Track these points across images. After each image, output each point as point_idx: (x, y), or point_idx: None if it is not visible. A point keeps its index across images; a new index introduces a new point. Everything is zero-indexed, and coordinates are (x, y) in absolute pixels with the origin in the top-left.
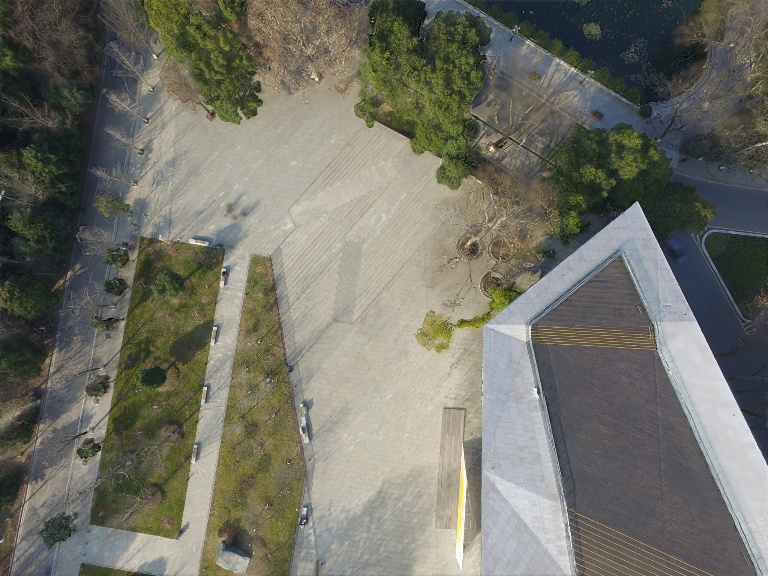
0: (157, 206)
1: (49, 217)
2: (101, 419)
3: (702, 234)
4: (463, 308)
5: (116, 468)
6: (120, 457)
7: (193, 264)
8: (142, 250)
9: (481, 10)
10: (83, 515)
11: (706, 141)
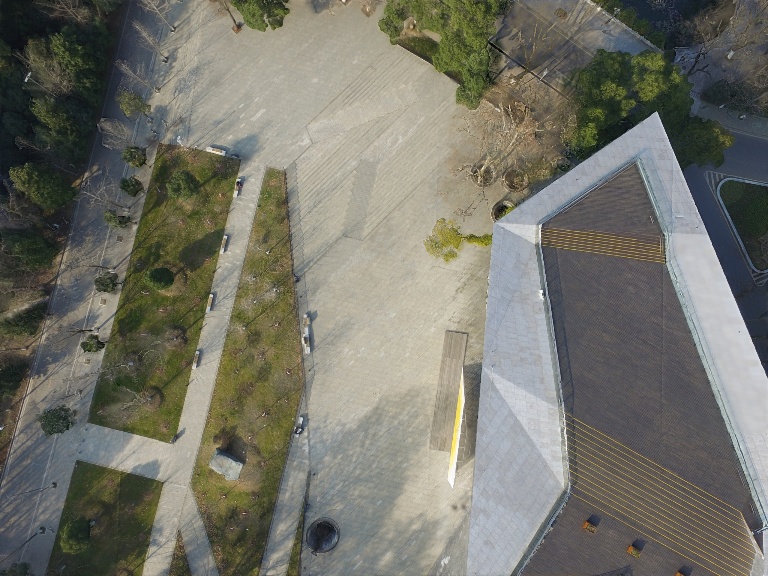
0: (177, 113)
1: (72, 110)
2: (107, 320)
3: (718, 182)
4: None
5: (118, 364)
6: (122, 358)
7: (208, 172)
8: (159, 156)
9: None
10: (82, 413)
11: (728, 87)
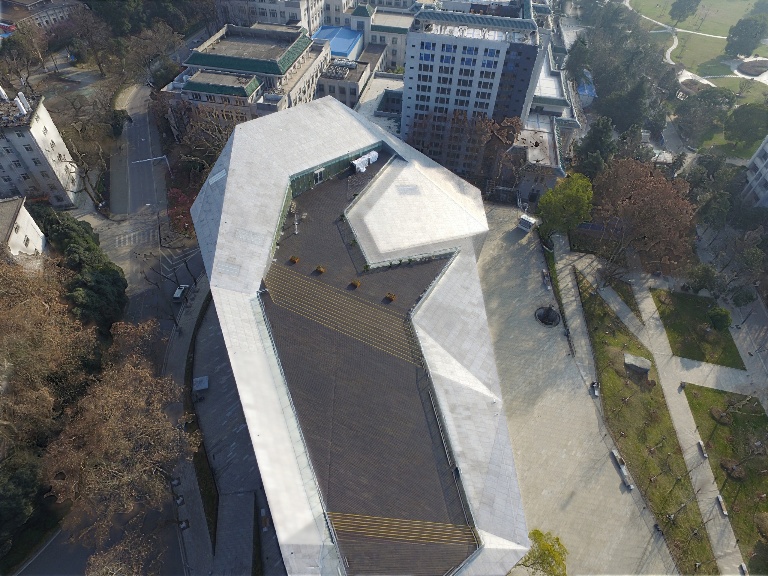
0: None
1: None
2: None
3: None
4: None
5: None
6: (767, 450)
7: None
8: None
9: None
10: (767, 405)
11: None
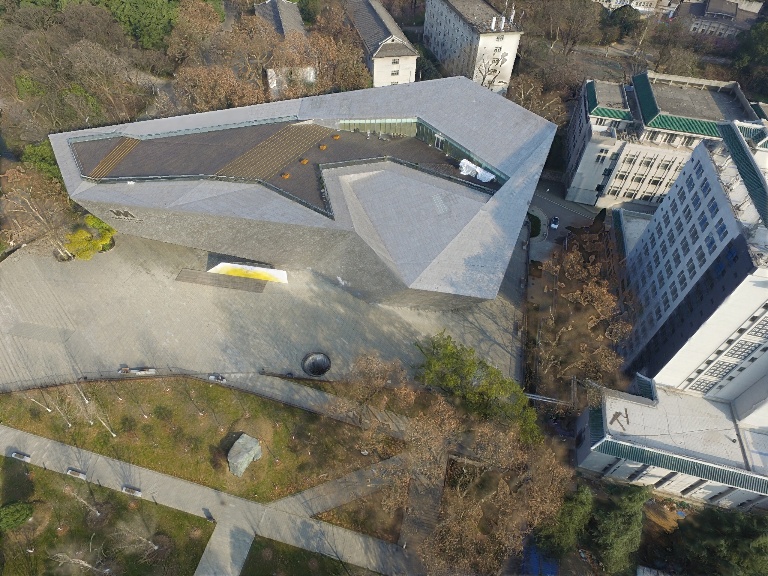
0: None
1: None
2: None
3: None
4: (109, 263)
5: None
6: None
7: None
8: None
9: None
10: None
11: None
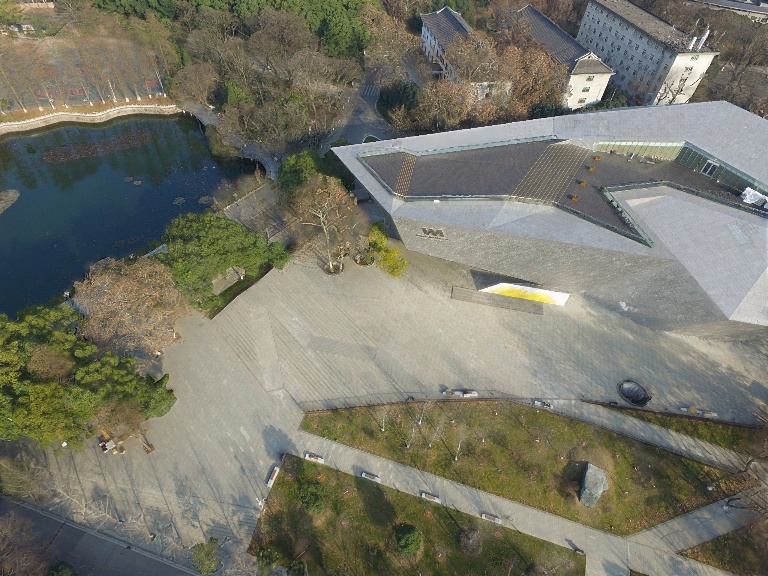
0: (220, 523)
1: None
2: None
3: None
4: (378, 278)
5: None
6: None
7: (293, 488)
8: None
9: (161, 245)
10: None
11: None
